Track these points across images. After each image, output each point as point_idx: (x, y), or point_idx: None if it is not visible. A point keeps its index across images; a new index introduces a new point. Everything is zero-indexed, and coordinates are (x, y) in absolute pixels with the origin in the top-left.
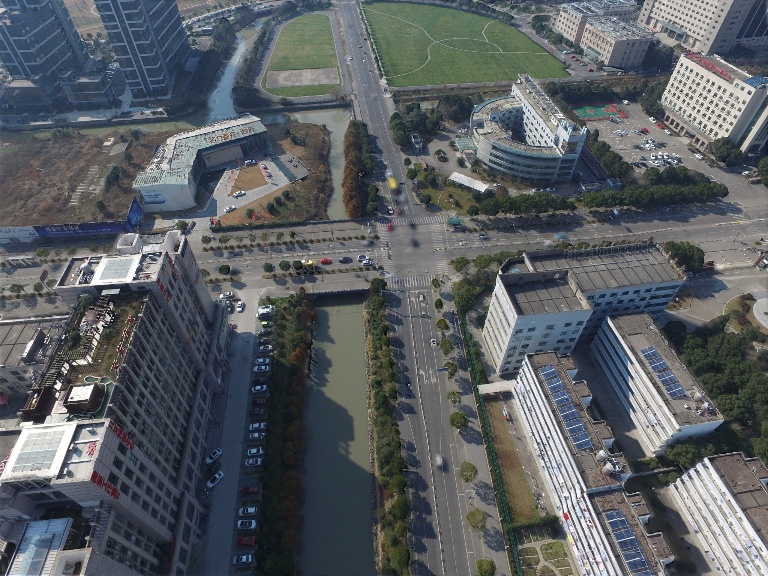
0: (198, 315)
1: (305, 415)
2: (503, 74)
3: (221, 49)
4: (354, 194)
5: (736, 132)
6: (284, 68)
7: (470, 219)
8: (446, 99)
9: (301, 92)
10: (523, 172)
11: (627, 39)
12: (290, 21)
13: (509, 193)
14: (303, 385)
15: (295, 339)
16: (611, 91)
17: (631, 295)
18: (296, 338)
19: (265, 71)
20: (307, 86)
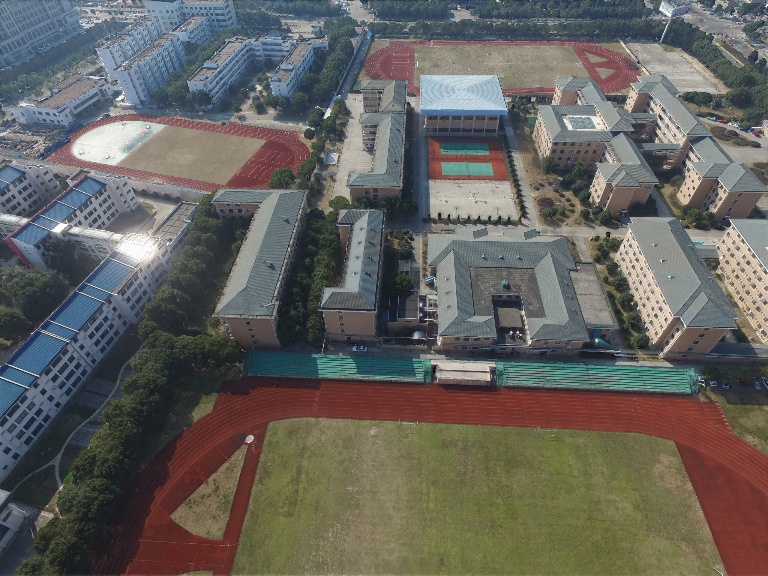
0: (57, 2)
1: (85, 46)
2: None
3: None
4: None
5: None
6: None
7: None
8: None
9: None
10: None
11: None
12: None
13: None
14: (93, 41)
15: (95, 25)
16: None
17: (204, 10)
18: (96, 24)
19: None
20: None
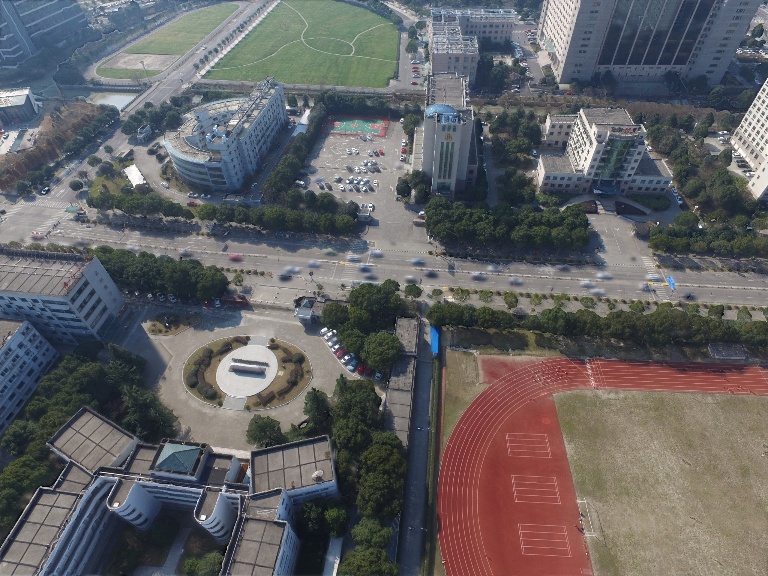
0: None
1: None
2: (321, 78)
3: (105, 29)
4: (12, 170)
5: (430, 165)
6: (137, 51)
7: (97, 211)
8: (205, 95)
9: (121, 75)
10: (186, 174)
11: (447, 52)
12: (200, 9)
13: (166, 193)
14: None
15: None
16: (387, 106)
17: (22, 302)
18: None
19: (118, 53)
20: (133, 70)
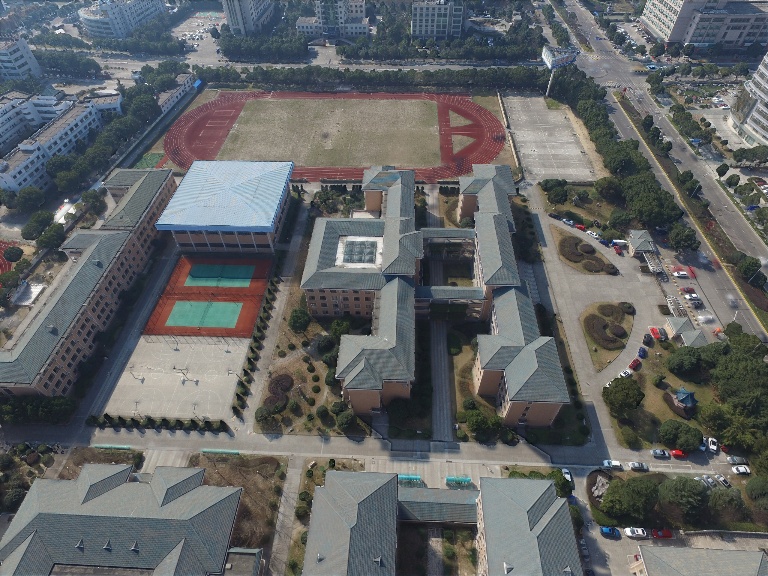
0: None
1: None
2: None
3: None
4: None
5: None
6: None
7: (36, 48)
8: None
9: None
10: (91, 31)
11: None
12: None
13: None
14: None
15: None
16: None
17: None
18: None
19: None
20: None
